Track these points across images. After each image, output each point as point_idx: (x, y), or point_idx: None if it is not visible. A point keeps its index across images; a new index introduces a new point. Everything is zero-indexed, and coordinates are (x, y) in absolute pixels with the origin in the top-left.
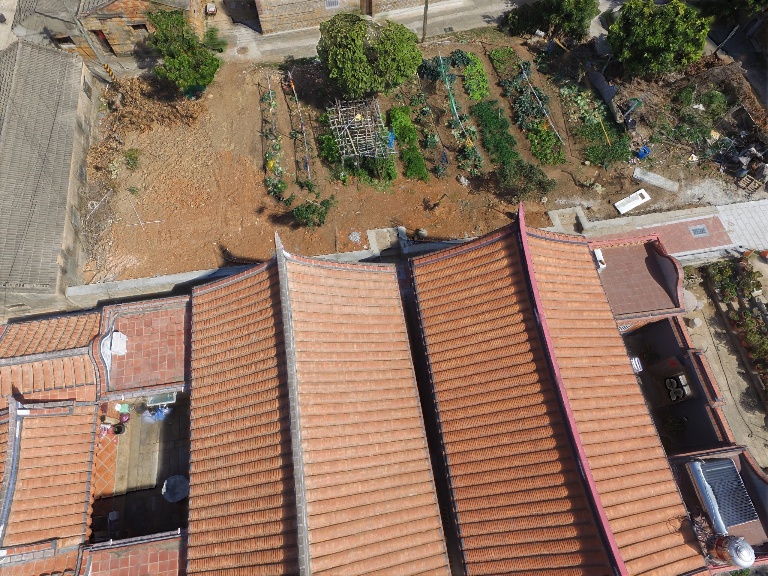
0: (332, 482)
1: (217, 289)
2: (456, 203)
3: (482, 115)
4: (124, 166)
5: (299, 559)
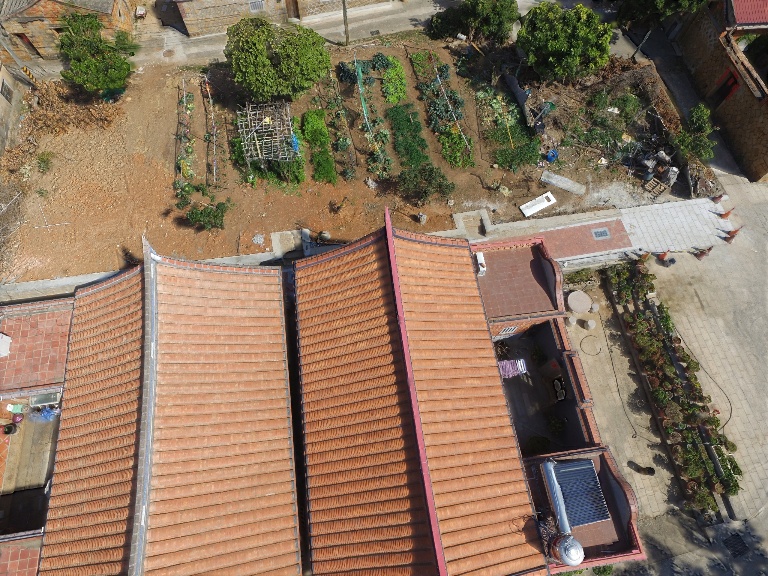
0: (183, 482)
1: (97, 291)
2: (362, 206)
3: (396, 118)
4: (36, 169)
5: (130, 557)
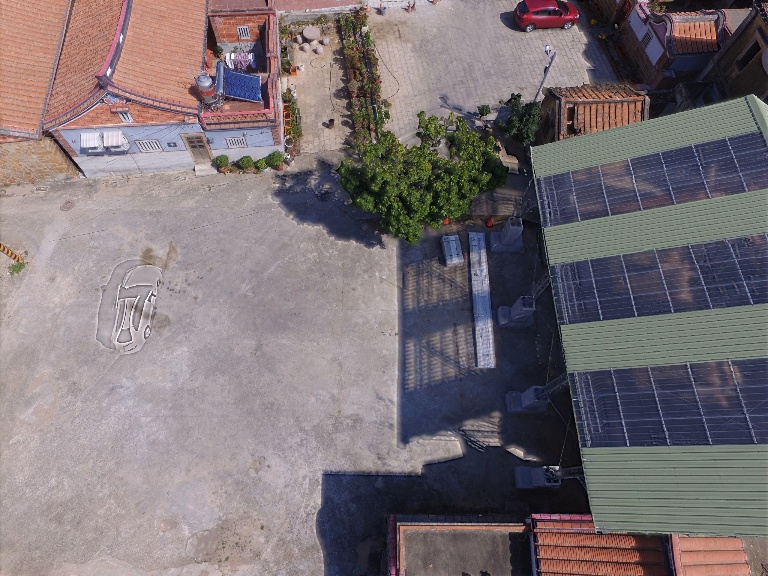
0: None
1: None
2: None
3: None
4: None
5: None
